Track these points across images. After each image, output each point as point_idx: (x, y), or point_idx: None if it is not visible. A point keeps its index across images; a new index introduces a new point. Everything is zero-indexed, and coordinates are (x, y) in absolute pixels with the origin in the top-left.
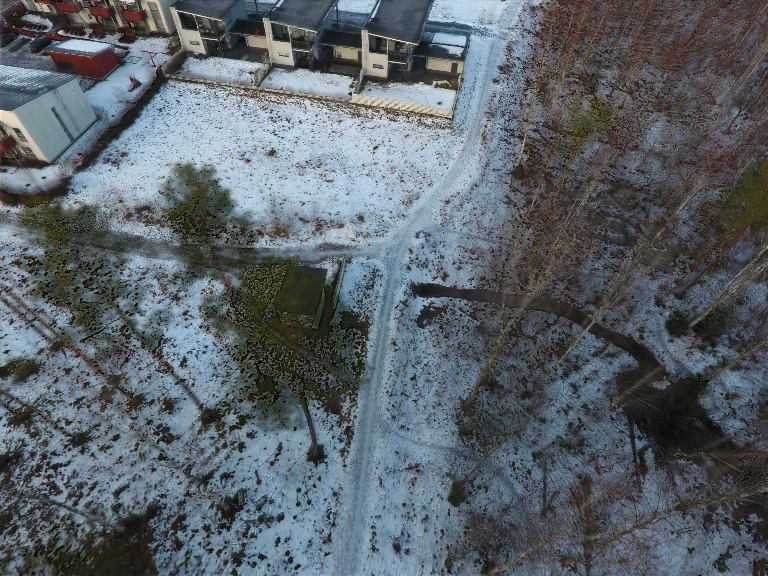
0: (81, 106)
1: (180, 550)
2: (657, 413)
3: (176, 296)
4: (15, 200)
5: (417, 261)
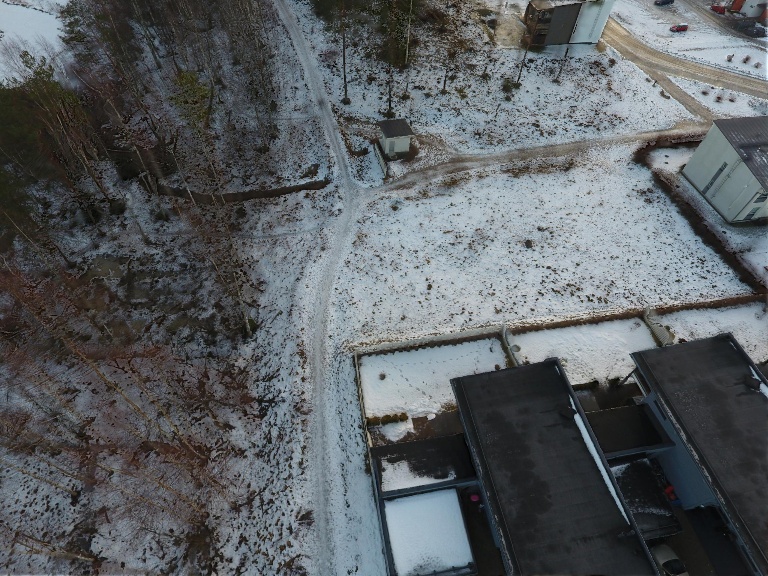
0: (737, 199)
1: (381, 67)
2: (155, 160)
3: (479, 135)
4: (656, 146)
5: (332, 194)
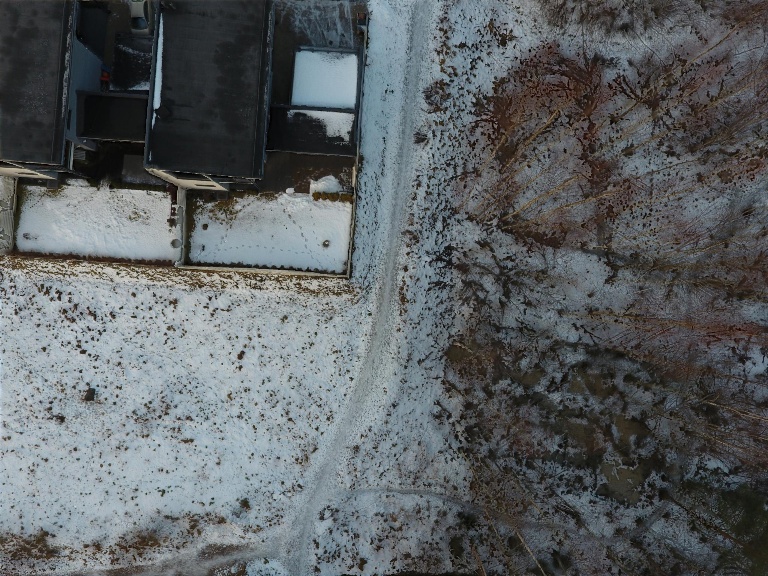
0: None
1: None
2: None
3: None
4: None
5: (326, 555)
